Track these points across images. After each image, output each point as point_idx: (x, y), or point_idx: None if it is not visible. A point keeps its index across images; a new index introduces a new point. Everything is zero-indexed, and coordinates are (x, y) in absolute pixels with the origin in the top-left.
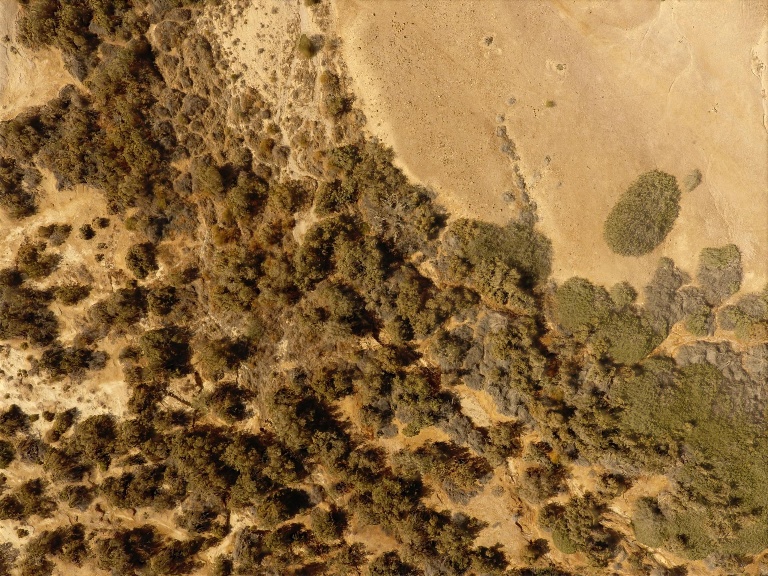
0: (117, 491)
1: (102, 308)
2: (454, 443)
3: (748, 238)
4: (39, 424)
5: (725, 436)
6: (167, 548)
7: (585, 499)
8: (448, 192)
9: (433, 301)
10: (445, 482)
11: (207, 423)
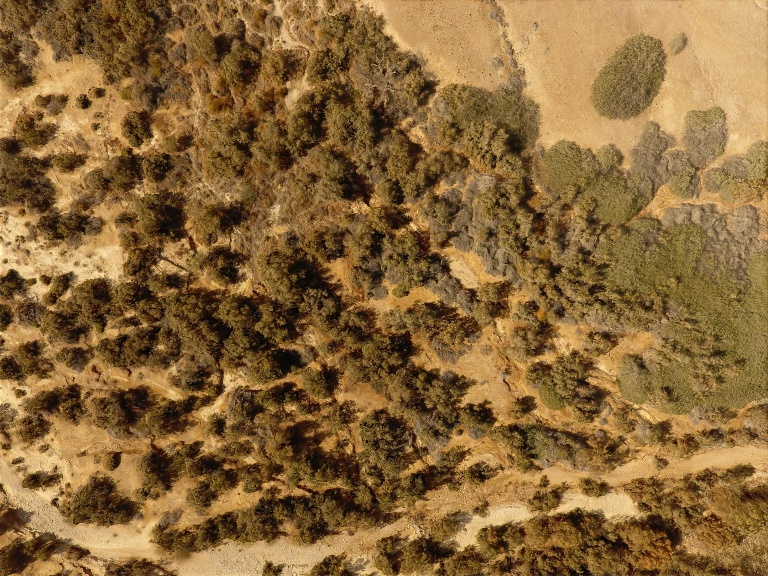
0: (113, 350)
1: (98, 172)
2: (443, 303)
3: (733, 100)
4: (36, 288)
5: (709, 292)
6: (162, 407)
7: (571, 356)
8: (438, 58)
9: (422, 162)
10: (434, 341)
11: (201, 287)
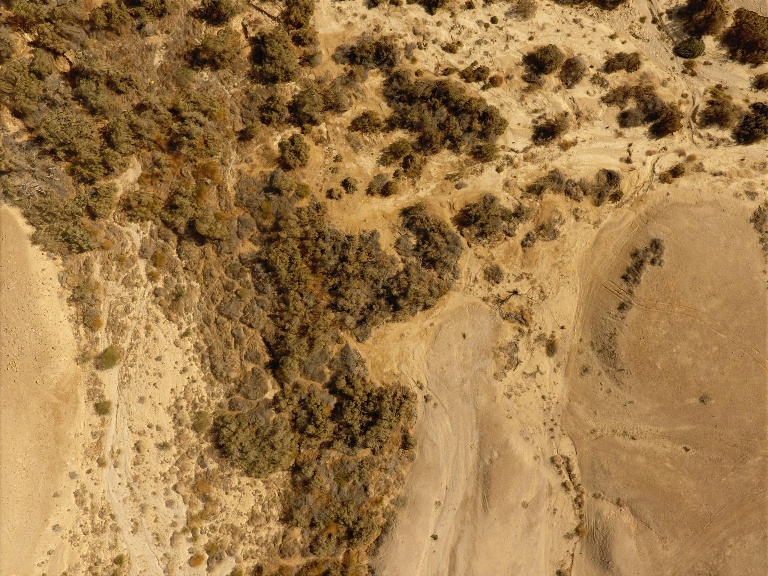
0: None
1: (329, 102)
2: None
3: None
4: None
5: None
6: None
7: None
8: None
9: (1, 88)
10: None
11: None
